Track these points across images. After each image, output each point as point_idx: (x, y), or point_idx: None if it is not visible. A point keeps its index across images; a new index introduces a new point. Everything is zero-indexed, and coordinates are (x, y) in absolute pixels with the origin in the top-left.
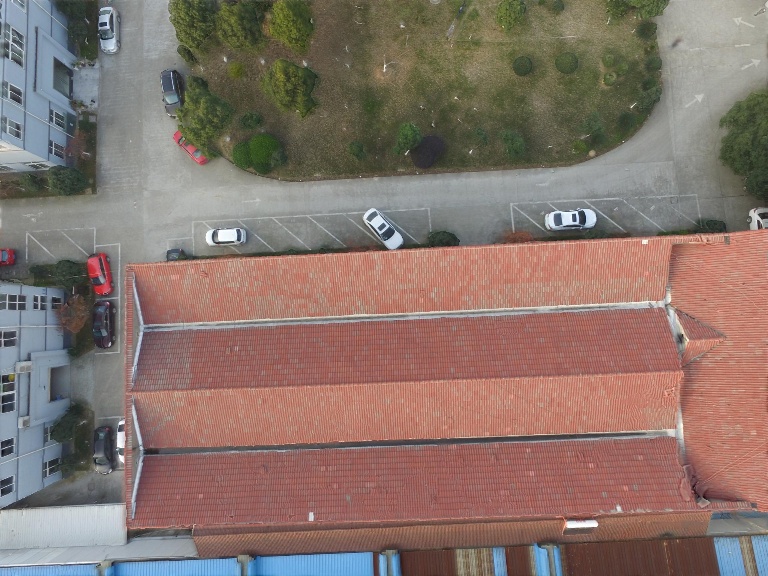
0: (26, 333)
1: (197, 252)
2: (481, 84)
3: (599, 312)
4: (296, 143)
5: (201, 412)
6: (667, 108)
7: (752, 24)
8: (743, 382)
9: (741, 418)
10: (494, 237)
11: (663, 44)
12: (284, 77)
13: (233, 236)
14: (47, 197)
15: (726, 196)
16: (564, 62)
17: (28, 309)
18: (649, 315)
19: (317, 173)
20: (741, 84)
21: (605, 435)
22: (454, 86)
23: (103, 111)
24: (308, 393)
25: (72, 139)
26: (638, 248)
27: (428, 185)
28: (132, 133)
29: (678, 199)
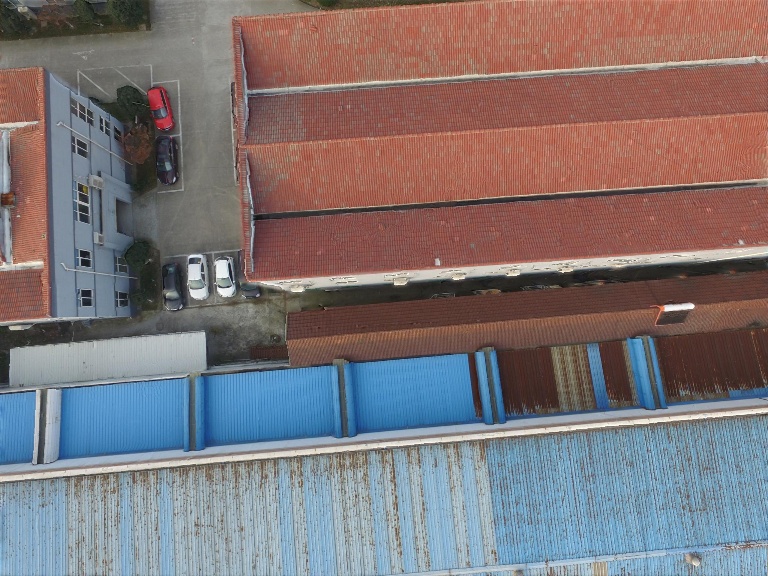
0: (95, 150)
1: None
2: None
3: (708, 67)
4: None
5: (316, 168)
6: None
7: None
8: None
9: None
10: None
11: None
12: None
13: None
14: (98, 34)
15: None
16: None
17: (95, 127)
18: (757, 68)
19: None
20: None
21: (717, 186)
22: None
23: None
24: (428, 142)
25: None
26: None
27: None
28: None
29: None
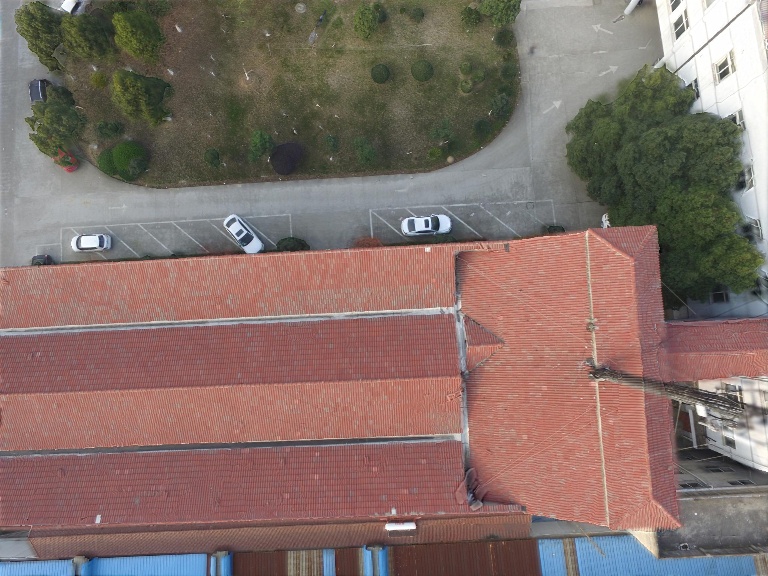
0: None
1: (65, 258)
2: (343, 91)
3: (391, 318)
4: (162, 150)
5: None
6: (525, 114)
7: (611, 31)
8: (517, 387)
9: (515, 423)
10: (353, 242)
11: (523, 51)
12: (121, 87)
13: (95, 242)
14: None
15: (581, 201)
16: (417, 70)
17: None
18: (438, 321)
19: (182, 180)
20: (598, 90)
21: (394, 439)
22: (317, 94)
23: None
24: (100, 398)
25: None
26: (422, 256)
27: (290, 191)
28: (5, 141)
29: (534, 204)
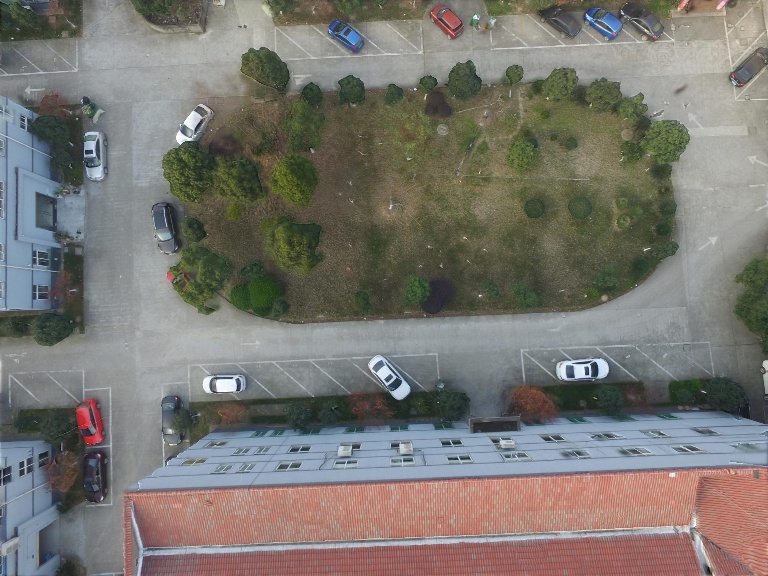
0: (12, 507)
1: (193, 398)
2: (491, 223)
3: (623, 538)
4: (298, 283)
5: None
6: (680, 251)
7: (767, 163)
8: None
9: None
10: (504, 385)
11: (677, 183)
12: (288, 247)
13: (232, 387)
14: (31, 336)
15: (739, 344)
16: (578, 209)
17: (14, 480)
18: (674, 542)
19: (320, 315)
20: (755, 227)
21: None
22: (463, 225)
23: (90, 243)
24: None
25: (57, 281)
26: (665, 480)
27: (436, 329)
28: (122, 268)
29: (691, 346)
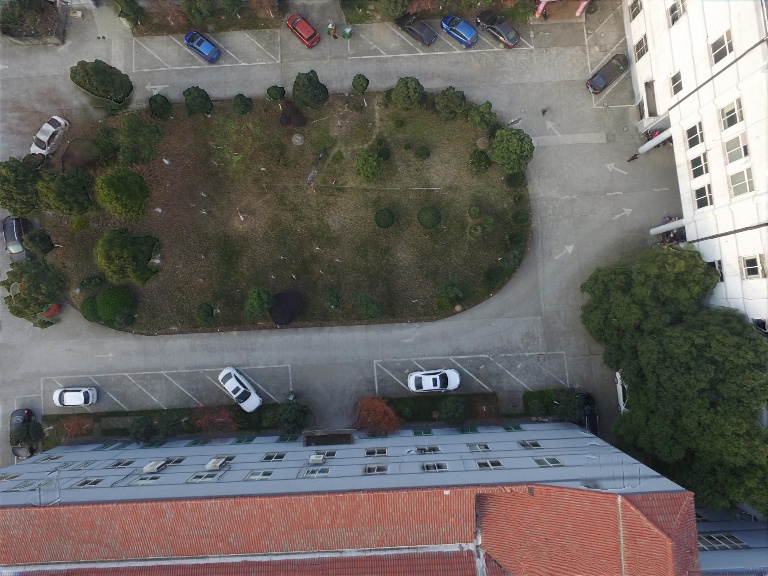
0: None
1: (46, 410)
2: (344, 233)
3: (406, 556)
4: (150, 294)
5: None
6: (536, 260)
7: (625, 171)
8: None
9: None
10: (356, 396)
11: (534, 191)
12: (106, 261)
13: (79, 400)
14: None
15: (594, 354)
16: (424, 219)
17: None
18: (457, 560)
19: (173, 326)
20: (612, 235)
21: None
22: (316, 235)
23: None
24: None
25: None
26: (440, 498)
27: (289, 340)
28: None
29: (545, 356)
